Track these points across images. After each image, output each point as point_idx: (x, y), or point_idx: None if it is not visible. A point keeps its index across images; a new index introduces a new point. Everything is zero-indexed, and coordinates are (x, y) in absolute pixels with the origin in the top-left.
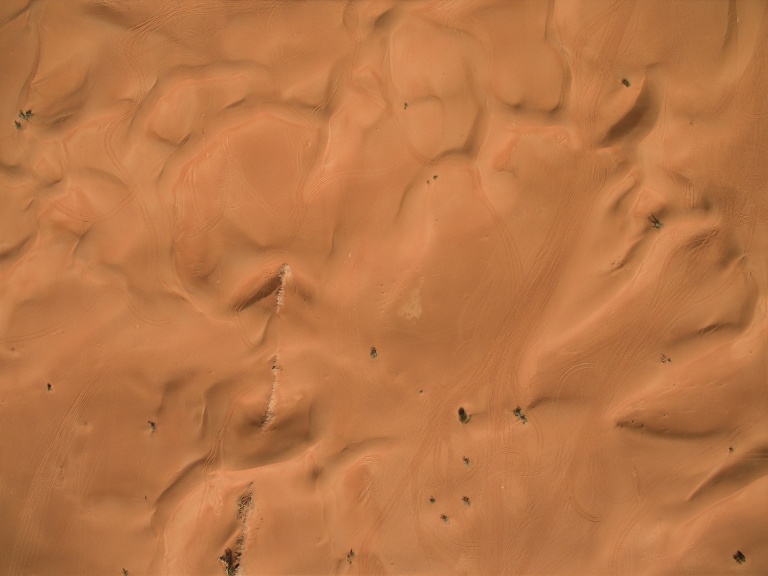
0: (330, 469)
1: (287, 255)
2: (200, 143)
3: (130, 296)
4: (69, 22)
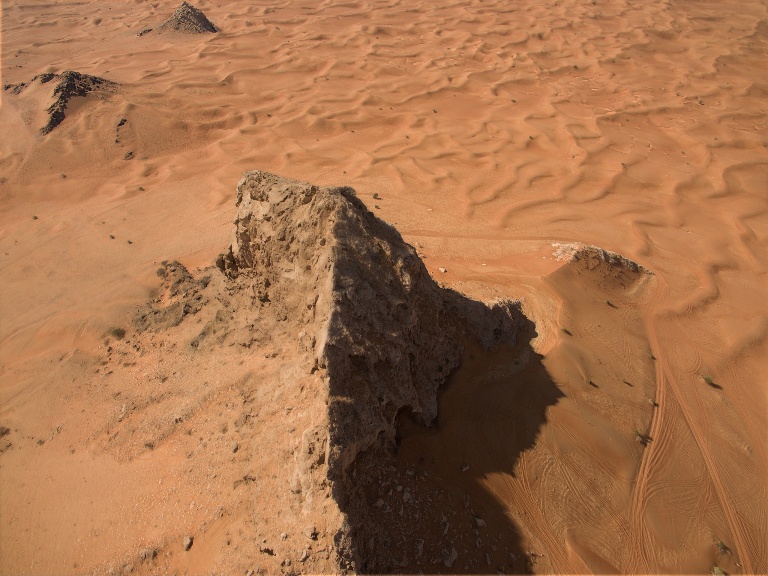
0: (130, 0)
1: (155, 8)
2: (178, 6)
3: (178, 0)
4: (211, 6)
